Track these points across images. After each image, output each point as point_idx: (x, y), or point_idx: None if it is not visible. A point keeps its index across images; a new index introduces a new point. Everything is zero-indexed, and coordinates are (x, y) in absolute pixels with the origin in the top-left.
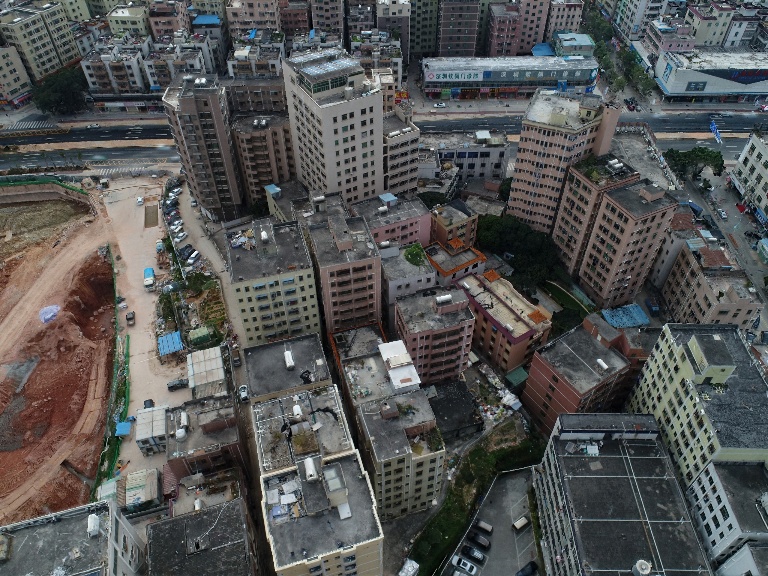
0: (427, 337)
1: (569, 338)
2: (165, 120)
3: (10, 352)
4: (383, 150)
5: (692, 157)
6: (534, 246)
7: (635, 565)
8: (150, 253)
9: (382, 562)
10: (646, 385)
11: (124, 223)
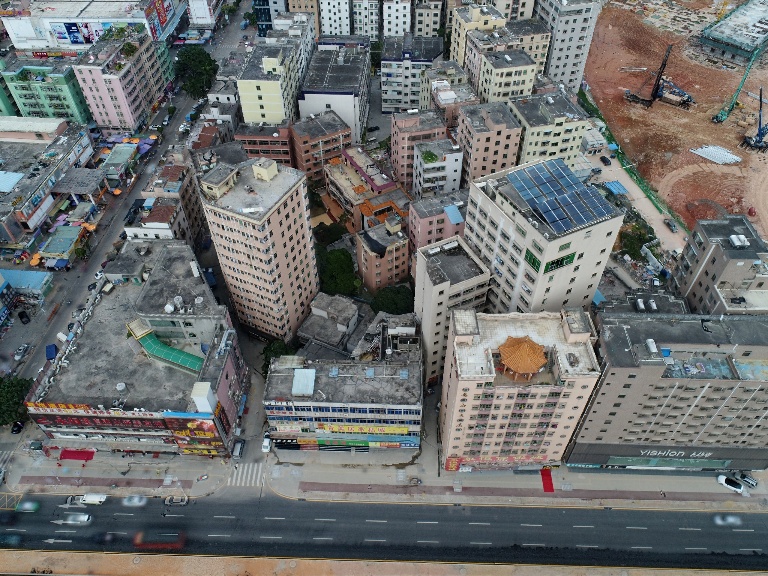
0: None
1: None
2: None
3: None
4: None
5: None
6: None
7: None
8: None
9: None
10: None
11: None
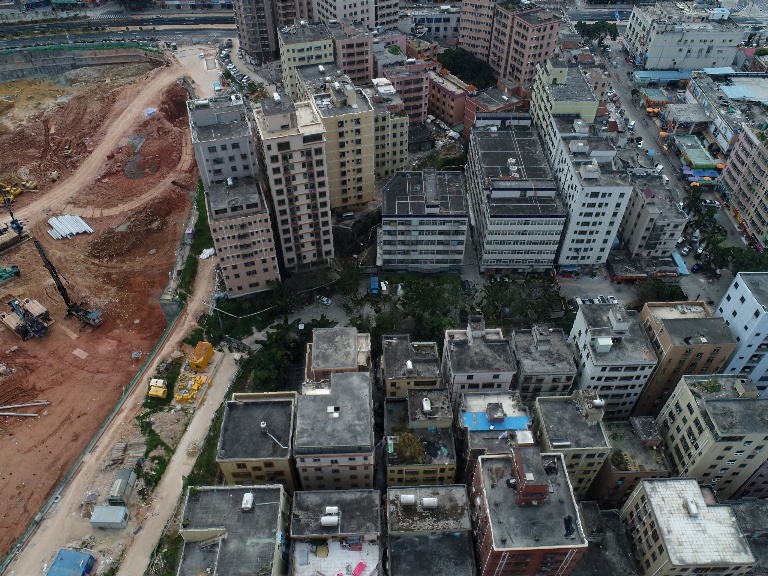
0: (401, 83)
1: (488, 92)
2: (211, 14)
3: (128, 131)
4: (374, 1)
5: (595, 26)
6: (475, 65)
7: (507, 161)
8: (214, 80)
9: (373, 140)
10: (531, 110)
11: (192, 67)
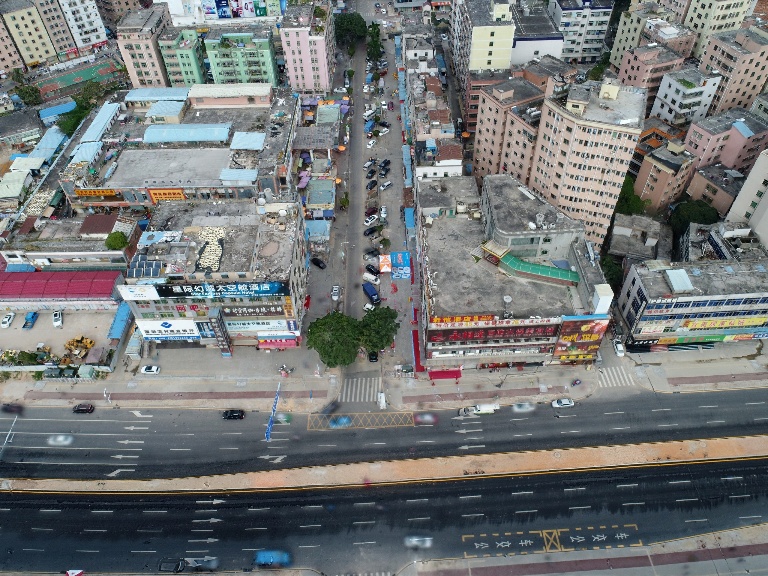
0: None
1: None
2: None
3: None
4: None
5: (358, 323)
6: None
7: None
8: None
9: None
10: None
11: None
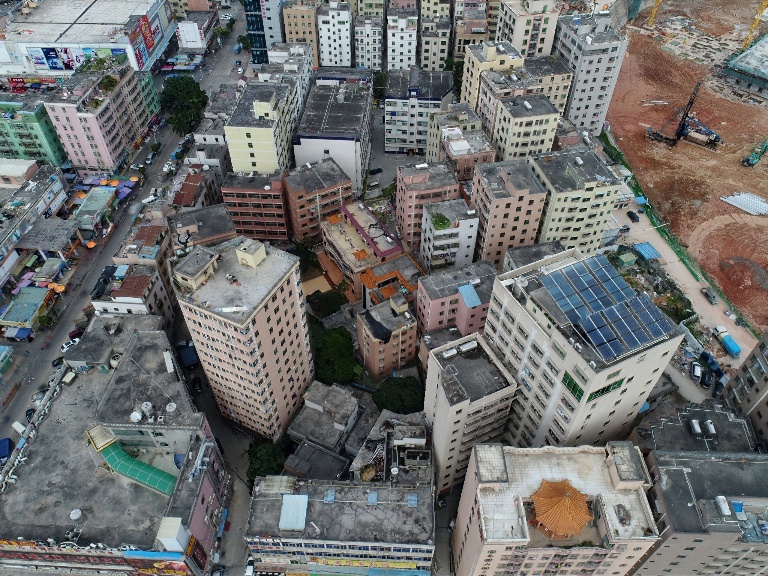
0: None
1: None
2: None
3: None
4: None
5: None
6: None
7: None
8: None
9: None
10: None
11: None
